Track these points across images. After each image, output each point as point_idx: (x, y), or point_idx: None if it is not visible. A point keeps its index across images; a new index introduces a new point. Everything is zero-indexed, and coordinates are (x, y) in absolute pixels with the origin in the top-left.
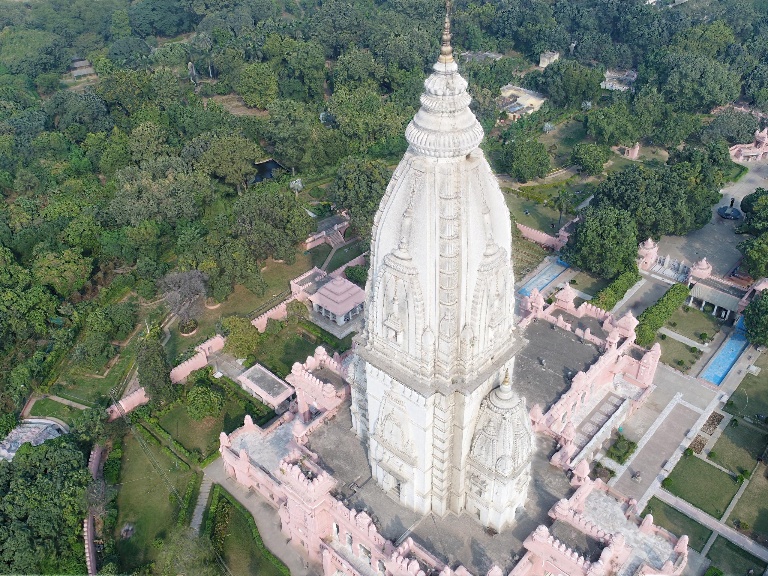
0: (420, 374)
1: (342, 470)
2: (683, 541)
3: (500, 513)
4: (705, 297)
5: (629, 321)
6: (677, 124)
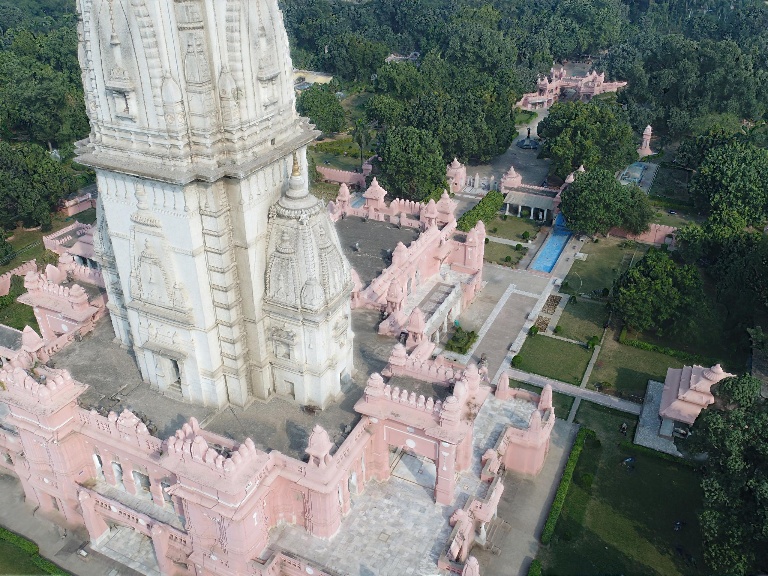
0: (169, 157)
1: (100, 383)
2: (546, 392)
3: (319, 377)
4: (520, 202)
5: (446, 202)
6: (465, 78)
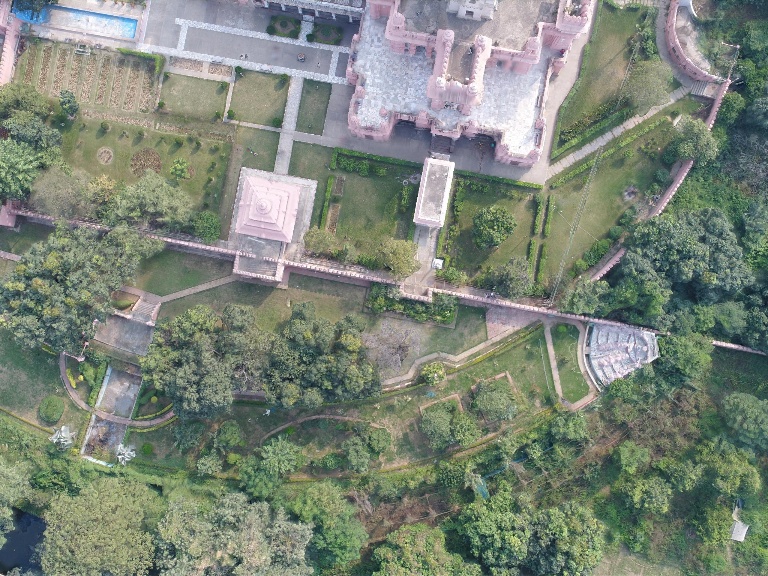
0: None
1: None
2: None
3: None
4: None
5: None
6: None
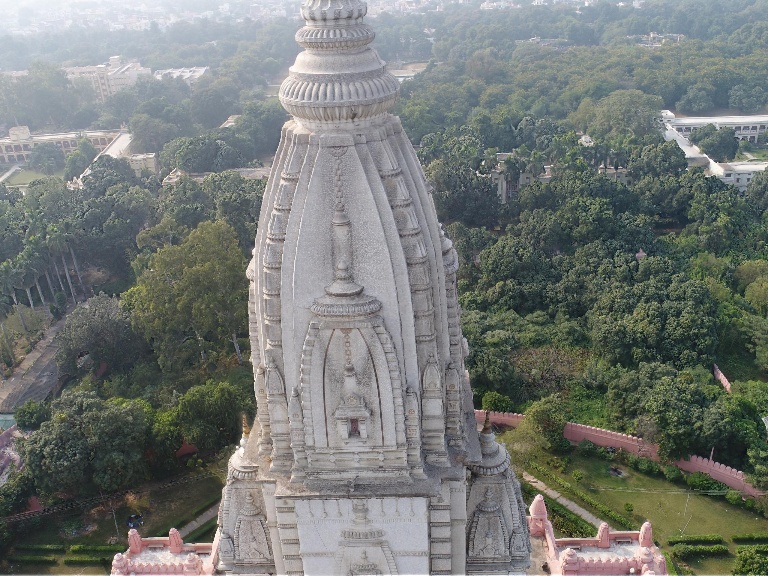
0: None
1: None
2: None
3: None
4: None
5: None
6: None
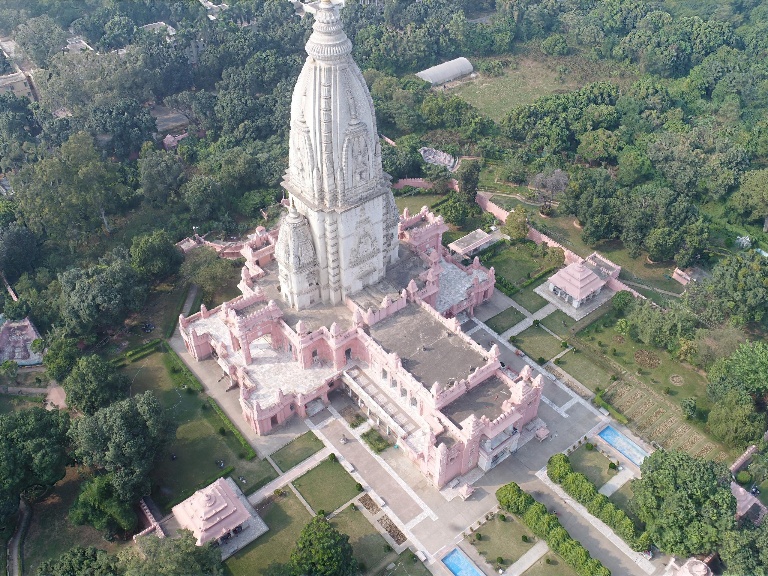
0: None
1: None
2: None
3: None
4: None
5: (467, 419)
6: None
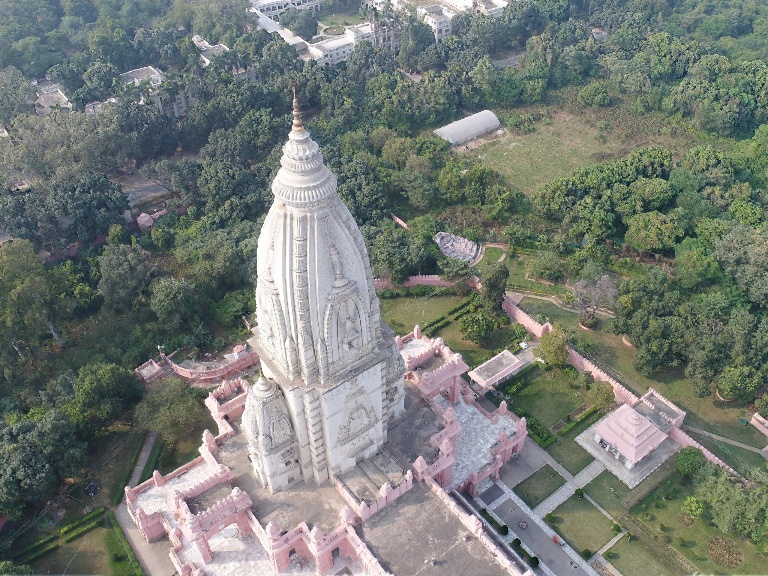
0: None
1: None
2: None
3: None
4: None
5: None
6: None
